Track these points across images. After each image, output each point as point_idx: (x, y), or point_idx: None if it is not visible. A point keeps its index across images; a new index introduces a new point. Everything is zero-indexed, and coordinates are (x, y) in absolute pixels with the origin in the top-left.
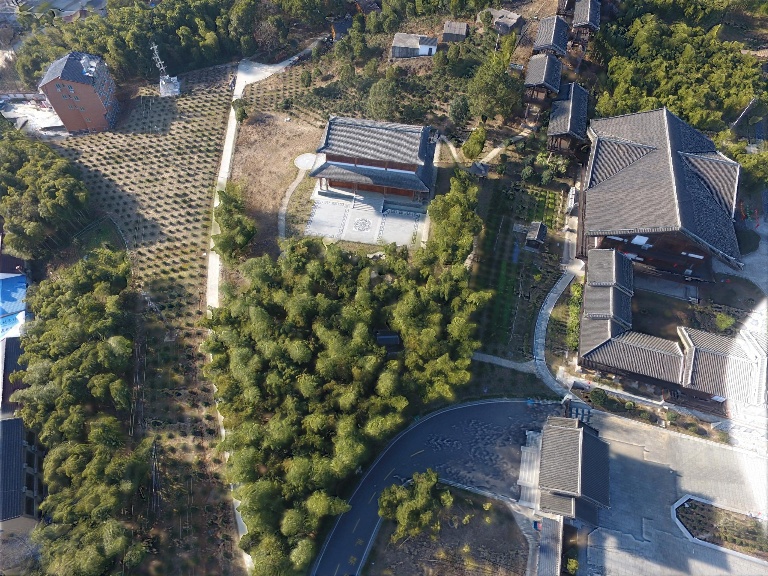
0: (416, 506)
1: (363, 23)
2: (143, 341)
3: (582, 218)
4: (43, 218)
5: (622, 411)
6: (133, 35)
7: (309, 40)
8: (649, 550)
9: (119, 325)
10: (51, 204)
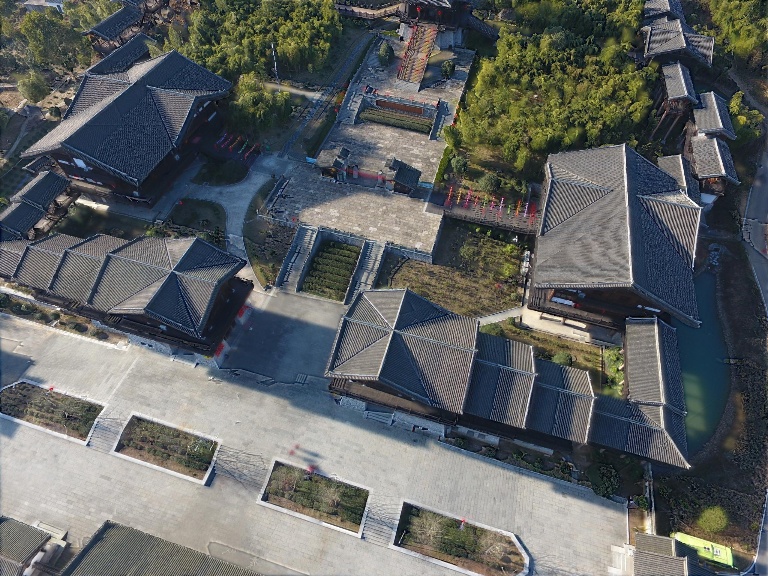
0: None
1: None
2: None
3: None
4: None
5: (26, 314)
6: None
7: None
8: None
9: None
10: None
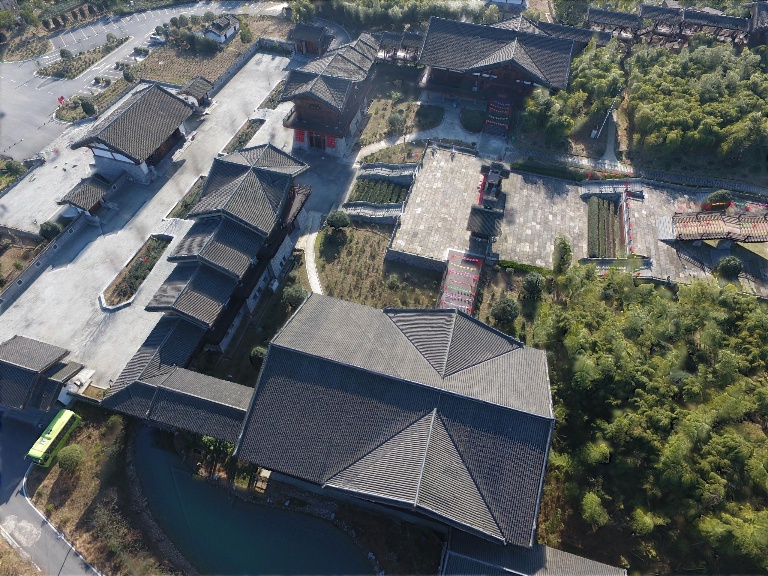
0: None
1: None
2: None
3: None
4: None
5: None
6: None
7: None
8: None
9: None
10: None
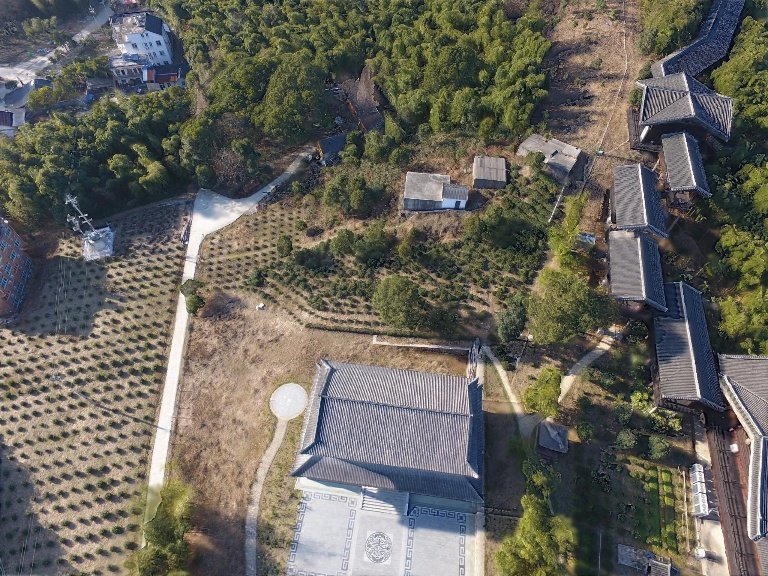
0: None
1: (360, 142)
2: None
3: (735, 556)
4: None
5: None
6: (45, 176)
7: (288, 157)
8: None
9: None
10: None
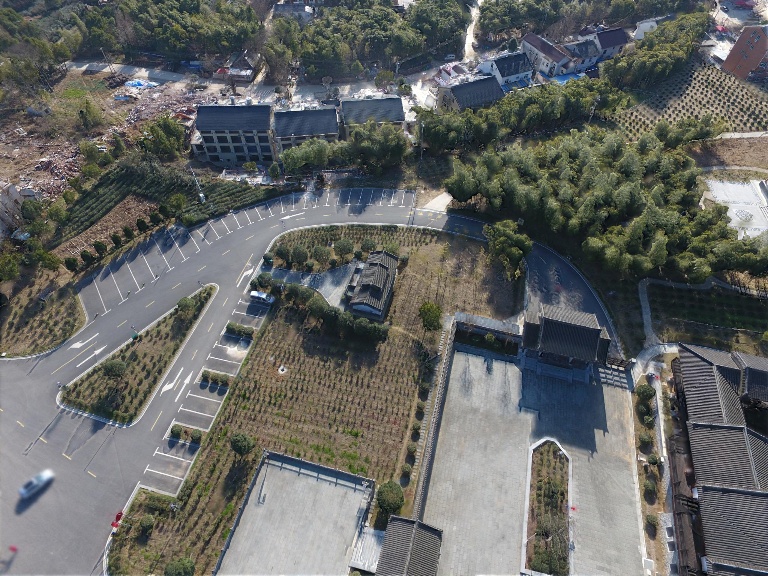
0: (508, 230)
1: None
2: (568, 128)
3: None
4: (632, 66)
5: (640, 420)
6: None
7: None
8: (513, 409)
9: (573, 106)
10: (644, 60)
